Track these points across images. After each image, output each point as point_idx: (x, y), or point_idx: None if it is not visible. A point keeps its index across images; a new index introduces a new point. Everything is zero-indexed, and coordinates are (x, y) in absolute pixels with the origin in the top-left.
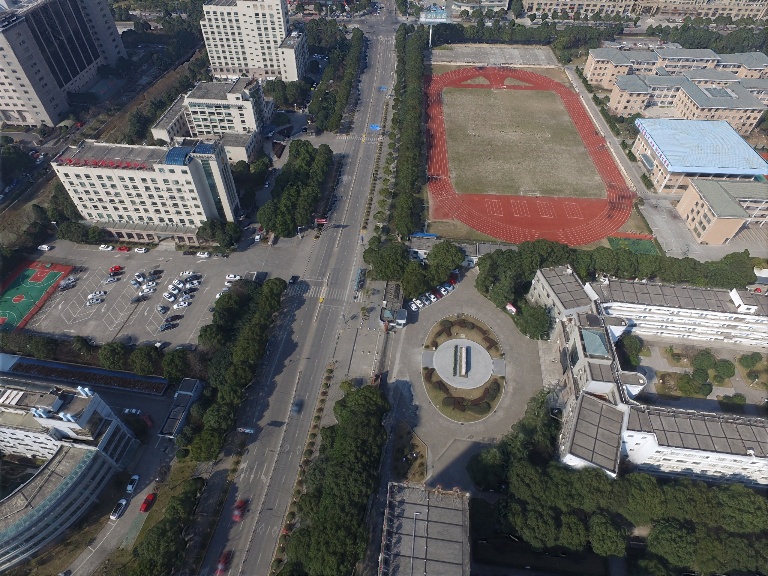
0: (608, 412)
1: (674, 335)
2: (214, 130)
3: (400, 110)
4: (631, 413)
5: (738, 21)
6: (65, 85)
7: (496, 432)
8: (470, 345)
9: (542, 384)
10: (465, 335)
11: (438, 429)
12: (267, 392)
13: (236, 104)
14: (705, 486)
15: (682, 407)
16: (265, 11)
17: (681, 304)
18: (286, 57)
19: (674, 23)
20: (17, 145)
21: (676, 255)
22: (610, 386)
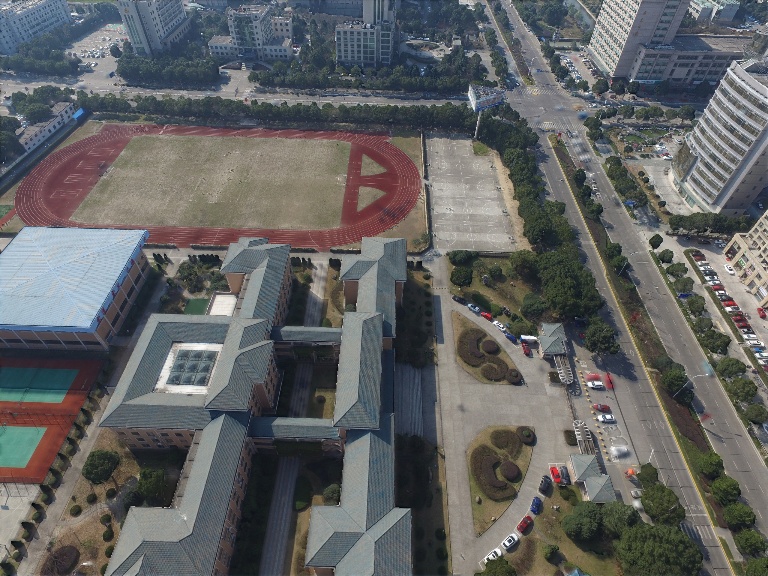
0: None
1: None
2: None
3: None
4: None
5: None
6: None
7: None
8: None
9: None
10: None
11: None
12: None
13: None
14: None
15: None
16: None
17: None
18: None
19: None
20: (256, 0)
21: None
22: None
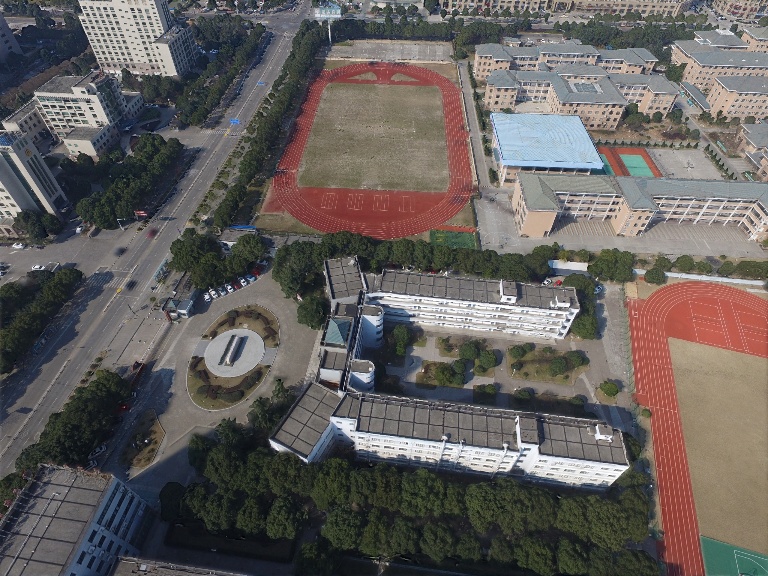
0: (329, 399)
1: (455, 326)
2: (69, 124)
3: (272, 105)
4: (345, 400)
5: (647, 17)
6: None
7: (240, 419)
8: (248, 335)
9: (305, 373)
10: (248, 325)
11: (183, 416)
12: (29, 380)
13: (83, 98)
14: (393, 471)
15: (435, 396)
16: (140, 6)
17: (447, 294)
18: (161, 52)
19: (587, 19)
20: None
21: (492, 248)
22: (337, 374)
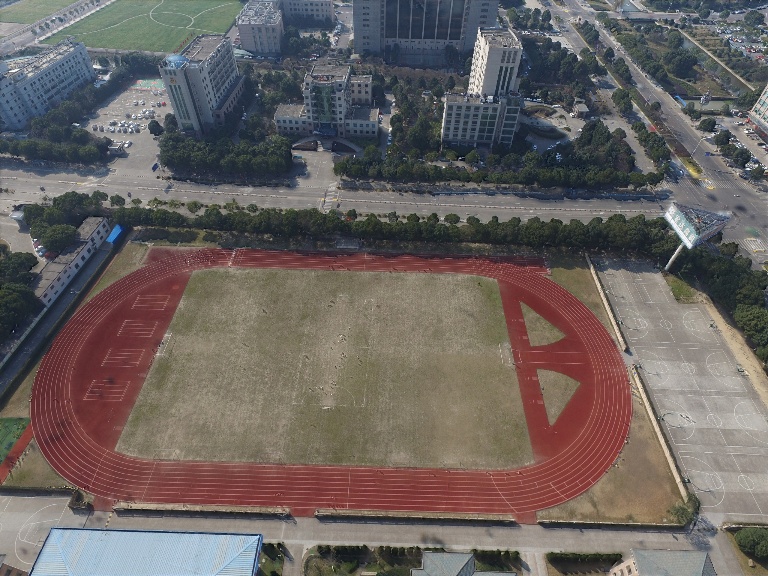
0: None
1: None
2: None
3: None
4: None
5: None
6: (398, 38)
7: None
8: None
9: None
10: None
11: None
12: (12, 168)
13: None
14: None
15: None
16: None
17: None
18: None
19: None
20: (315, 46)
21: None
22: None
